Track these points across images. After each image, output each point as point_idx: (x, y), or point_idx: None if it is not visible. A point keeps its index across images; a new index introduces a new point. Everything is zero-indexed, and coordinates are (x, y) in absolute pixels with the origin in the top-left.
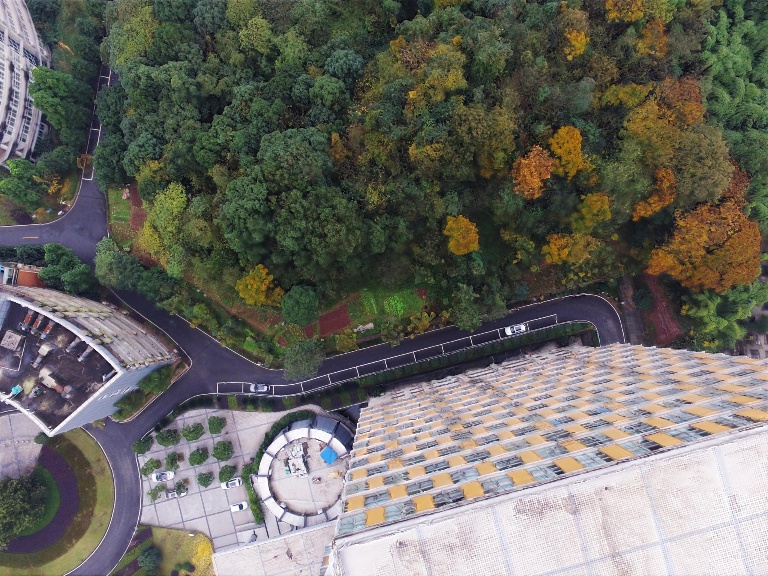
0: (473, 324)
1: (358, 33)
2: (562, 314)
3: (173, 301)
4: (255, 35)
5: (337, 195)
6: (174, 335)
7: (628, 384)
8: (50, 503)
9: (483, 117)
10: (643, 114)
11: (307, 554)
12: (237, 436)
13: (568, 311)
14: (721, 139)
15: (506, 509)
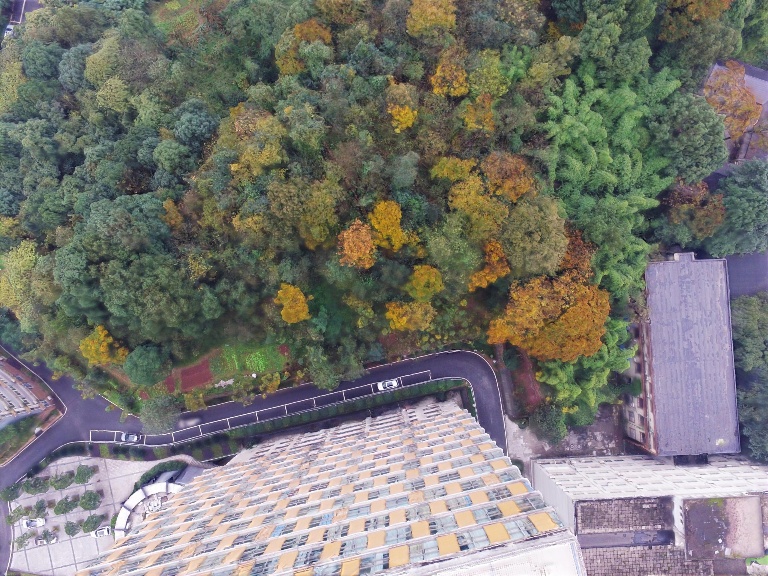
0: (329, 384)
1: (221, 92)
2: (436, 370)
3: (34, 353)
4: (109, 96)
5: (165, 263)
6: (50, 382)
7: (390, 481)
8: None
9: (295, 194)
10: (465, 190)
11: None
12: (109, 484)
13: (442, 367)
14: (554, 213)
15: None
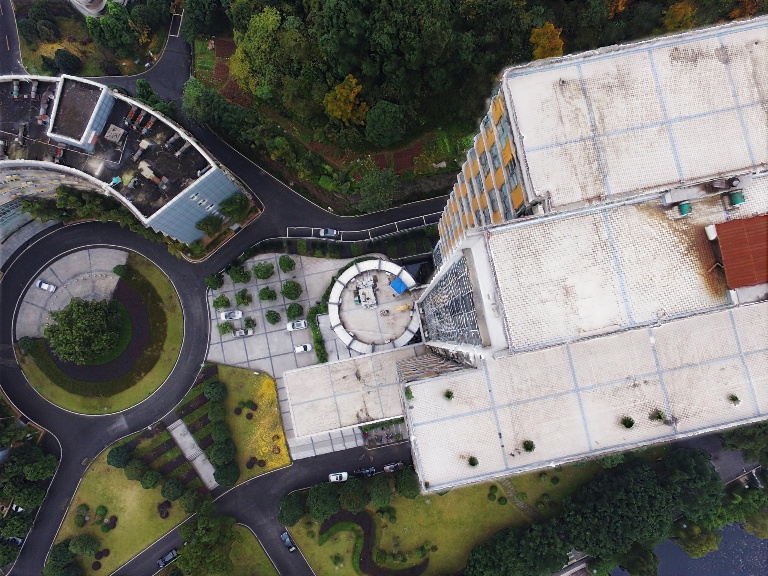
0: None
1: None
2: None
3: (257, 130)
4: None
5: None
6: (248, 181)
7: None
8: (123, 334)
9: None
10: None
11: (375, 376)
12: (304, 280)
13: None
14: None
15: (662, 56)
